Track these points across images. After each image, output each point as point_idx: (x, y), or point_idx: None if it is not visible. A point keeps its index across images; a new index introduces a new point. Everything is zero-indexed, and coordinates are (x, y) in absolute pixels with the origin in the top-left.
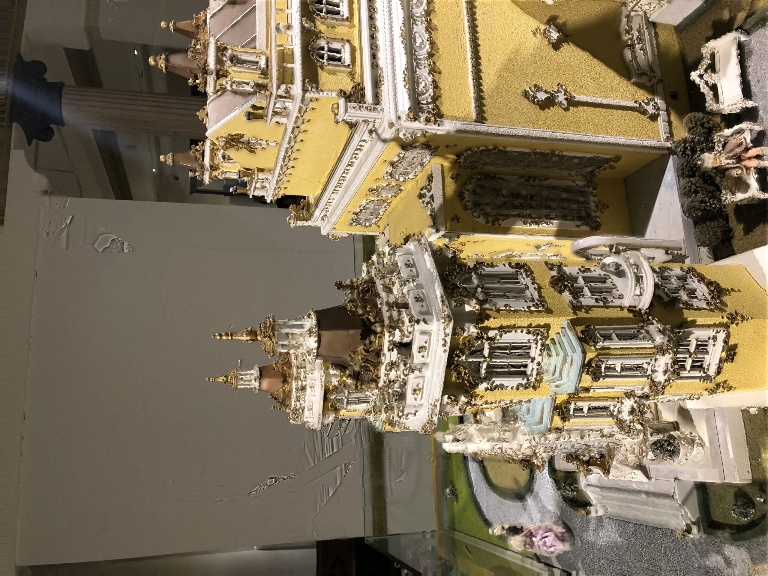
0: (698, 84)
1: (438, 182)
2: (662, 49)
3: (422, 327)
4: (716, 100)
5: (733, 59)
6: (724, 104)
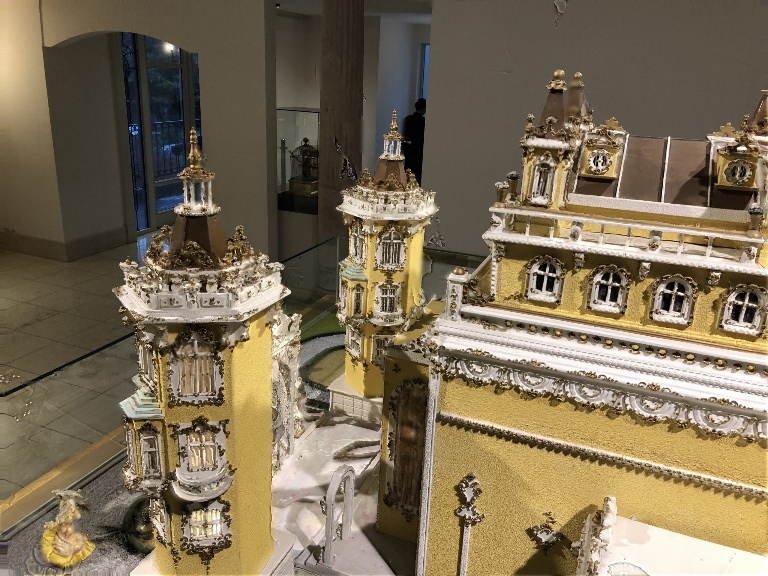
0: None
1: None
2: None
3: (146, 298)
4: None
5: None
6: None
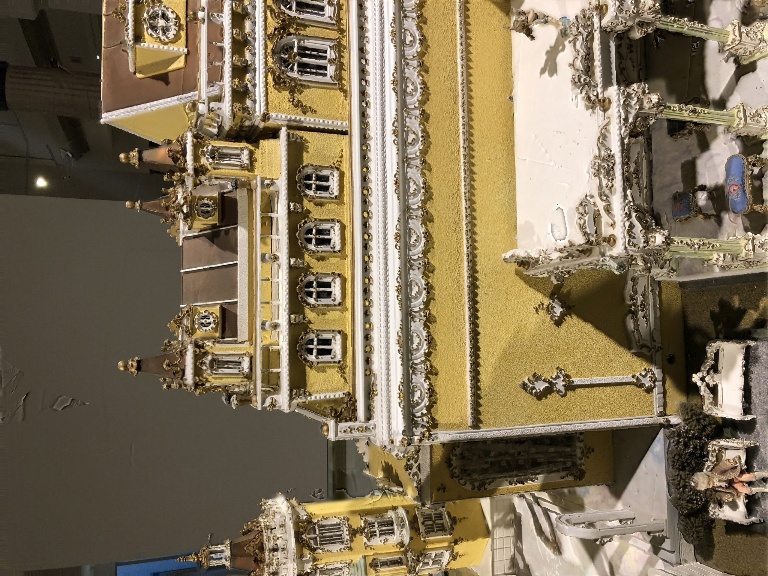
0: (699, 386)
1: (426, 450)
2: (665, 306)
3: None
4: (715, 402)
5: (738, 368)
6: (723, 407)
